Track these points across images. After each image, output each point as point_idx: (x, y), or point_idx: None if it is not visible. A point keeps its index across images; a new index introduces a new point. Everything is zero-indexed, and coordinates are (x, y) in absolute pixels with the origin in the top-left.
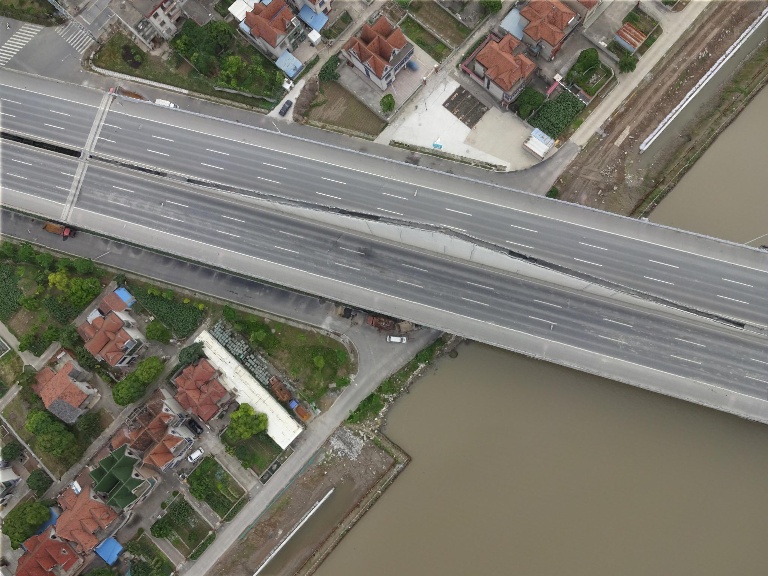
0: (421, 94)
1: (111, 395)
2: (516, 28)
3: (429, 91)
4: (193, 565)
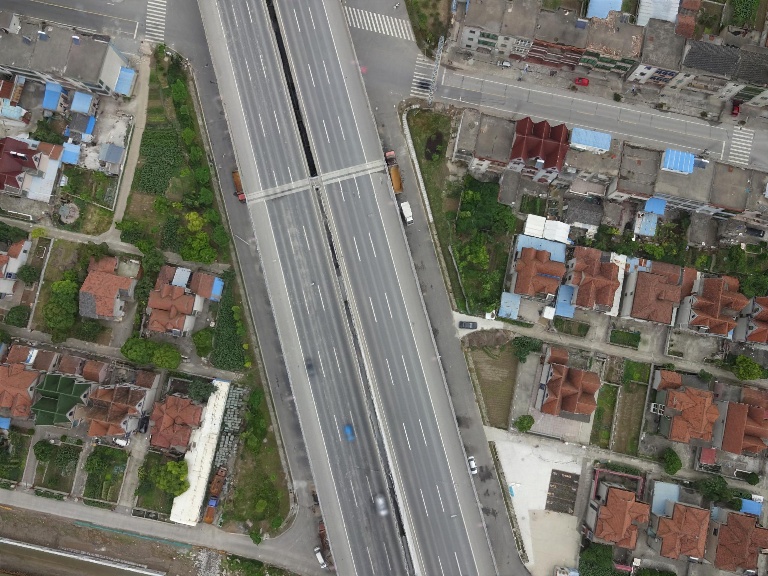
0: (552, 443)
1: (127, 329)
2: (661, 500)
3: (558, 449)
4: (32, 495)
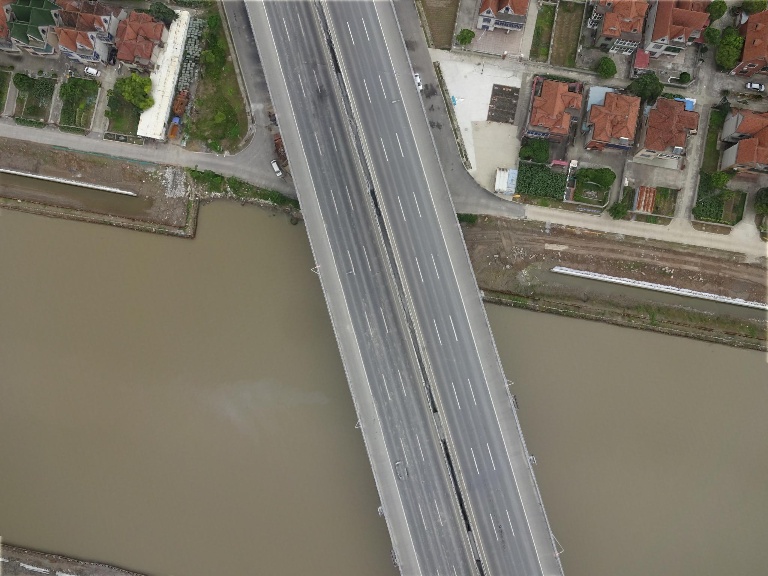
0: (493, 61)
1: None
2: (596, 101)
3: (499, 66)
4: (13, 125)
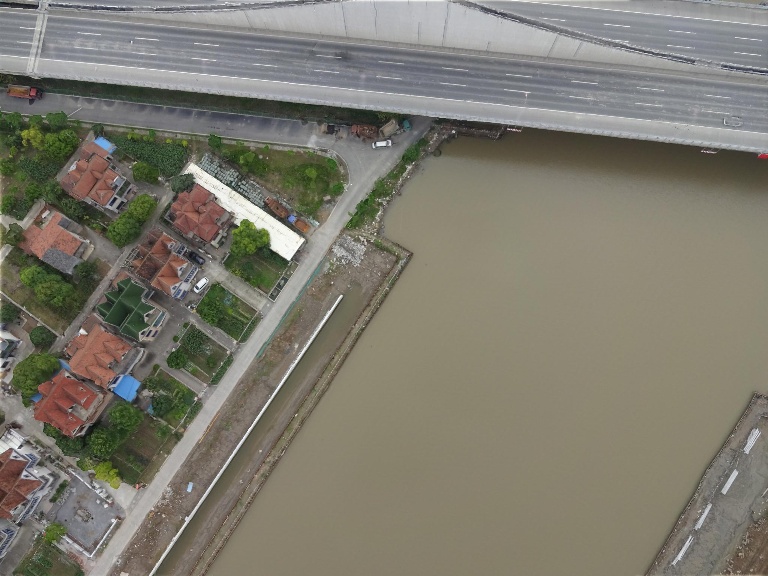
0: None
1: (105, 244)
2: None
3: None
4: (215, 390)
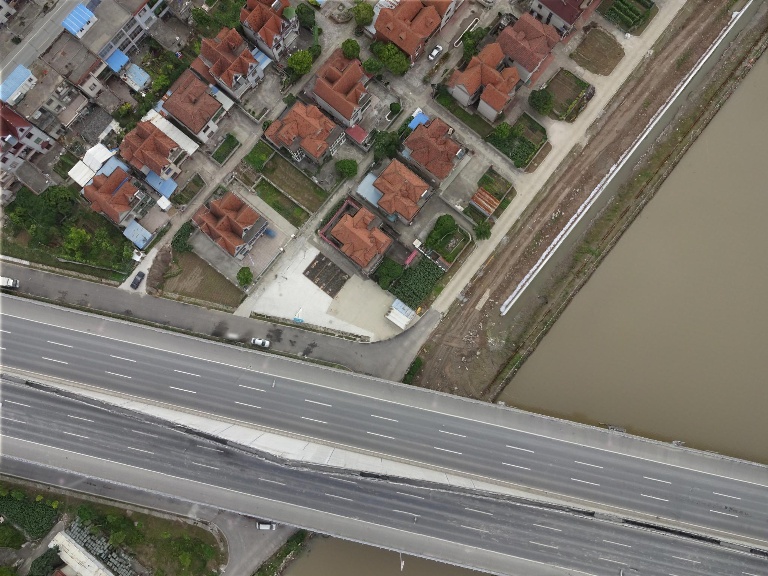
0: (280, 262)
1: None
2: (372, 194)
3: (288, 259)
4: None
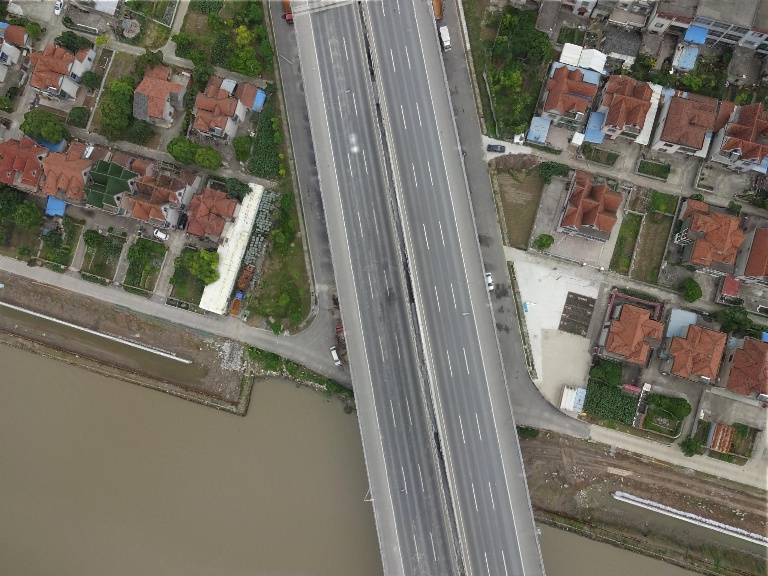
0: (570, 267)
1: (175, 136)
2: (677, 326)
3: (577, 273)
4: (79, 279)
